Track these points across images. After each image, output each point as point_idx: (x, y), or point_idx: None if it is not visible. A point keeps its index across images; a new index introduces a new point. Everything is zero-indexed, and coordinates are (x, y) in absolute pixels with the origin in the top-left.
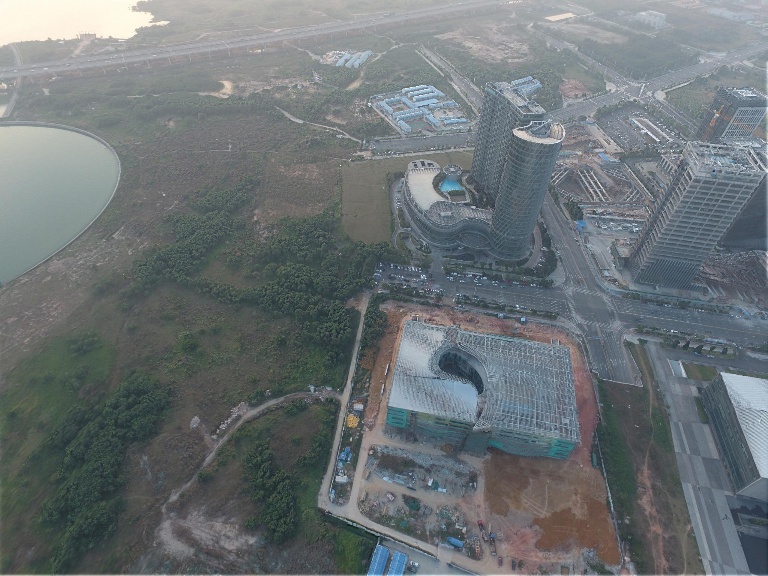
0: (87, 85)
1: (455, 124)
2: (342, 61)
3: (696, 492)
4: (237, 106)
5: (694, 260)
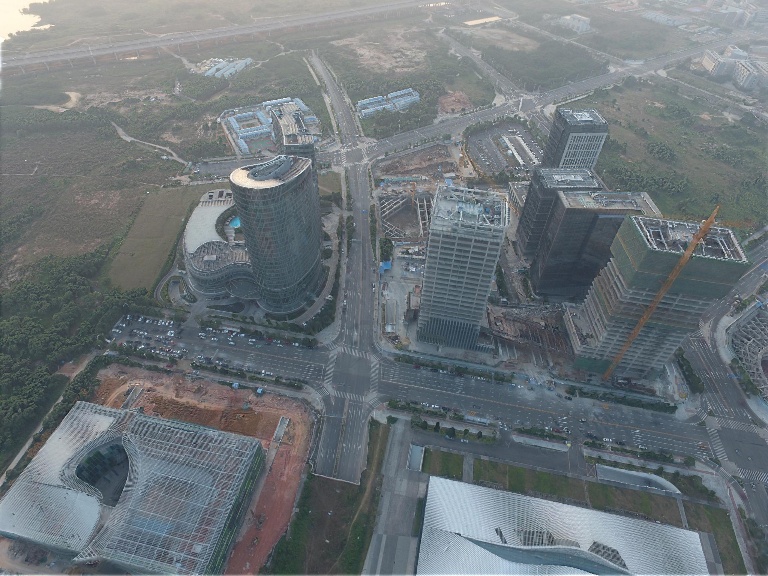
0: None
1: None
2: (213, 70)
3: None
4: (64, 122)
5: (470, 320)
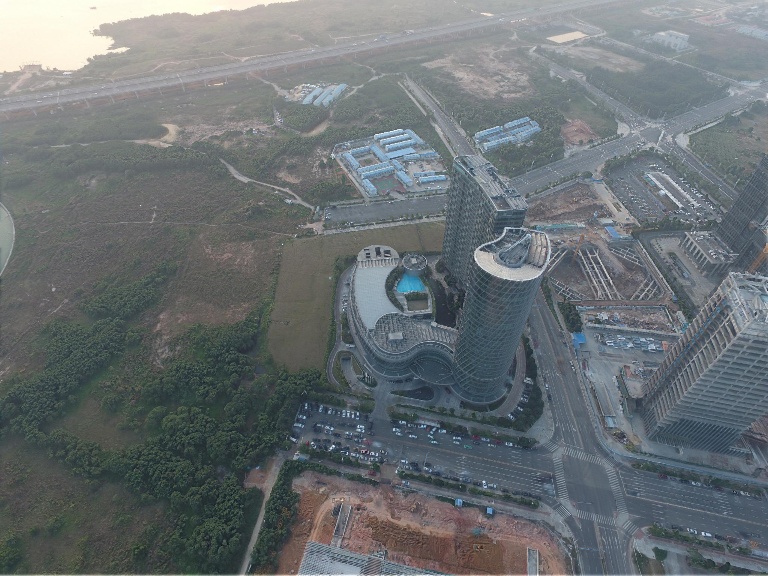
0: (10, 131)
1: (432, 183)
2: (310, 98)
3: None
4: (173, 160)
5: (734, 424)
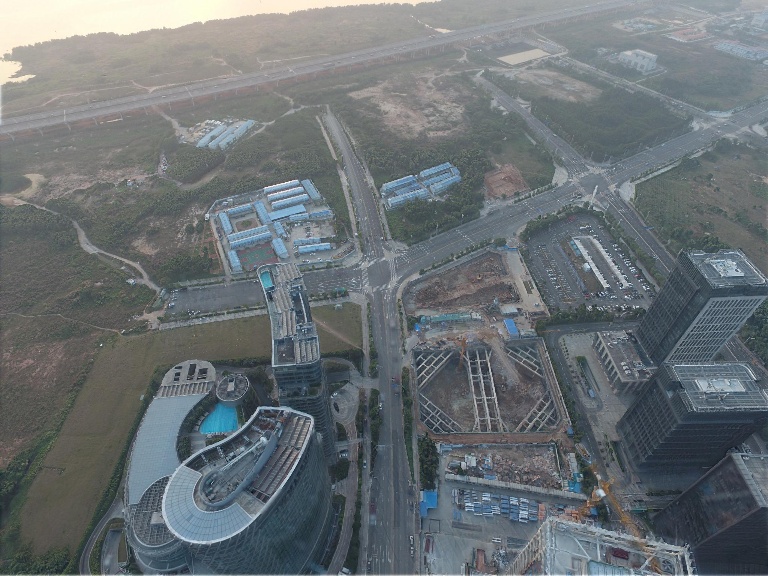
0: None
1: (312, 253)
2: (206, 139)
3: None
4: (13, 226)
5: None
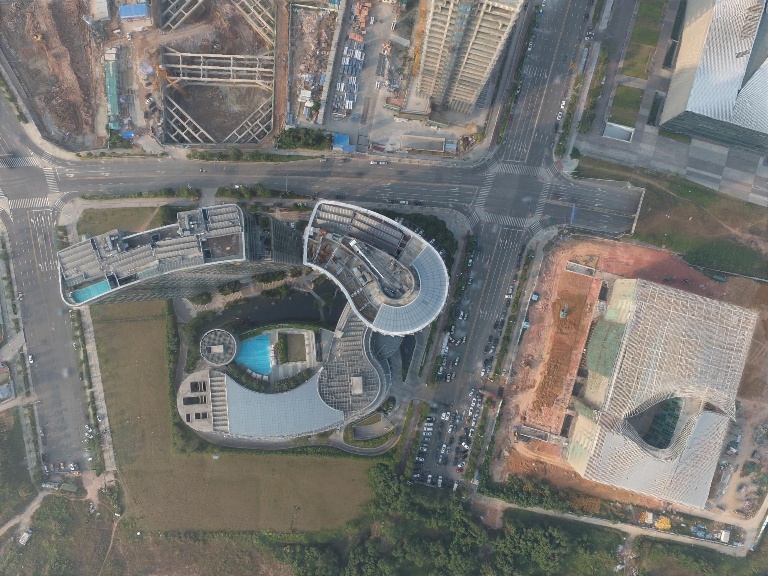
0: None
1: None
2: None
3: (758, 192)
4: None
5: None
